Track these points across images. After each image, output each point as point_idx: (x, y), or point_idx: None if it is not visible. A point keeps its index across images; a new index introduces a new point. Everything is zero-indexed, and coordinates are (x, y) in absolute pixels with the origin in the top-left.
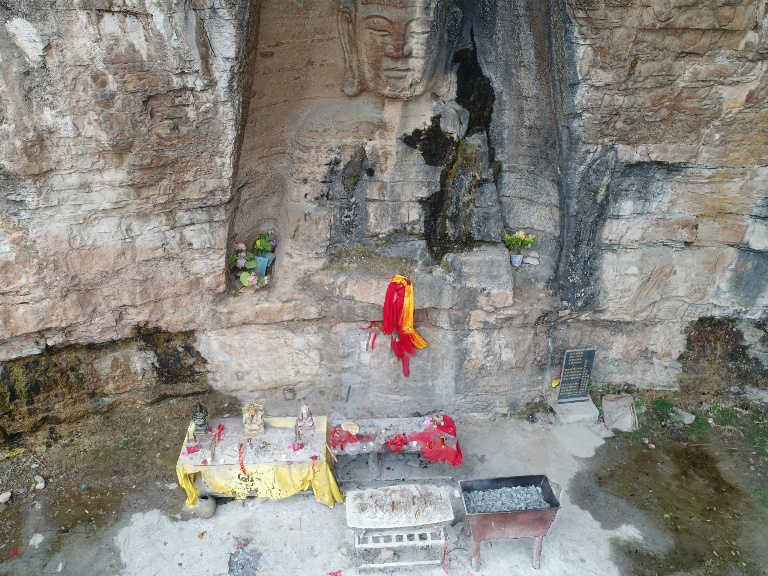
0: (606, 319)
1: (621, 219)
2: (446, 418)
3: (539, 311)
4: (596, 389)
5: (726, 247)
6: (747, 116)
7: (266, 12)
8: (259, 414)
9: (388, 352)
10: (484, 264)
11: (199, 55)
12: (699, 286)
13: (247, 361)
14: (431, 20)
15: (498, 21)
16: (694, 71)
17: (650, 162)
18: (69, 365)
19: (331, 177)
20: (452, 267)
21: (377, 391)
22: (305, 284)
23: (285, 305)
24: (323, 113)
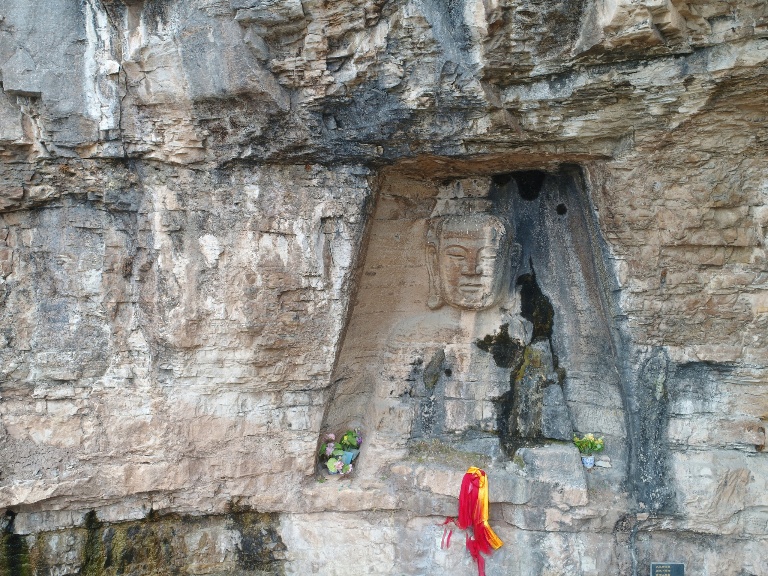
0: (690, 530)
1: (684, 419)
2: None
3: (616, 514)
4: None
5: None
6: None
7: (373, 243)
8: None
9: (463, 552)
10: (555, 458)
11: (323, 264)
12: None
13: (324, 551)
14: (497, 249)
15: (551, 252)
16: (718, 281)
17: (700, 363)
18: (164, 536)
19: (414, 376)
20: (524, 460)
21: None
22: (385, 474)
23: (366, 492)
24: (410, 322)
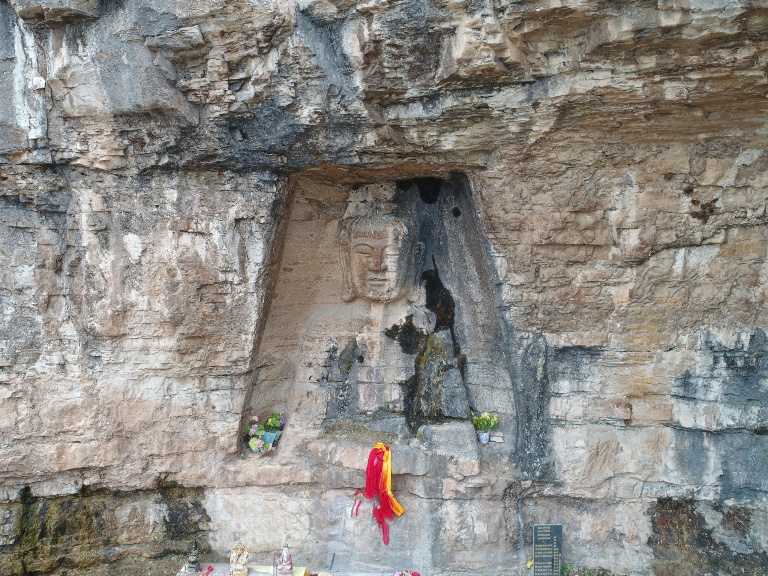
0: (569, 495)
1: (563, 398)
2: (415, 574)
3: (504, 482)
4: (572, 574)
5: (662, 427)
6: (635, 309)
7: (289, 242)
8: (245, 554)
9: (370, 519)
10: (451, 434)
11: (239, 260)
12: (646, 462)
13: (245, 521)
14: (400, 247)
15: (450, 250)
16: (583, 275)
17: (575, 348)
18: (95, 509)
19: (330, 362)
20: (424, 436)
21: (359, 559)
22: (302, 451)
23: (283, 468)
24: (326, 313)
